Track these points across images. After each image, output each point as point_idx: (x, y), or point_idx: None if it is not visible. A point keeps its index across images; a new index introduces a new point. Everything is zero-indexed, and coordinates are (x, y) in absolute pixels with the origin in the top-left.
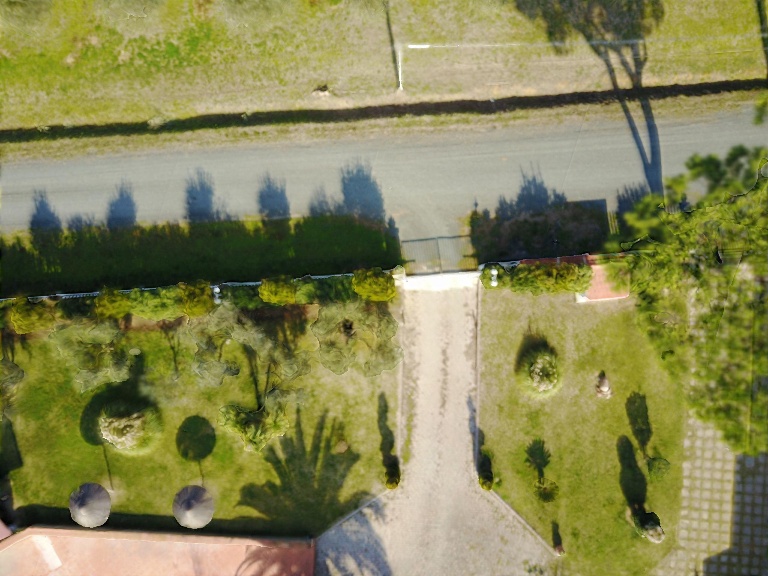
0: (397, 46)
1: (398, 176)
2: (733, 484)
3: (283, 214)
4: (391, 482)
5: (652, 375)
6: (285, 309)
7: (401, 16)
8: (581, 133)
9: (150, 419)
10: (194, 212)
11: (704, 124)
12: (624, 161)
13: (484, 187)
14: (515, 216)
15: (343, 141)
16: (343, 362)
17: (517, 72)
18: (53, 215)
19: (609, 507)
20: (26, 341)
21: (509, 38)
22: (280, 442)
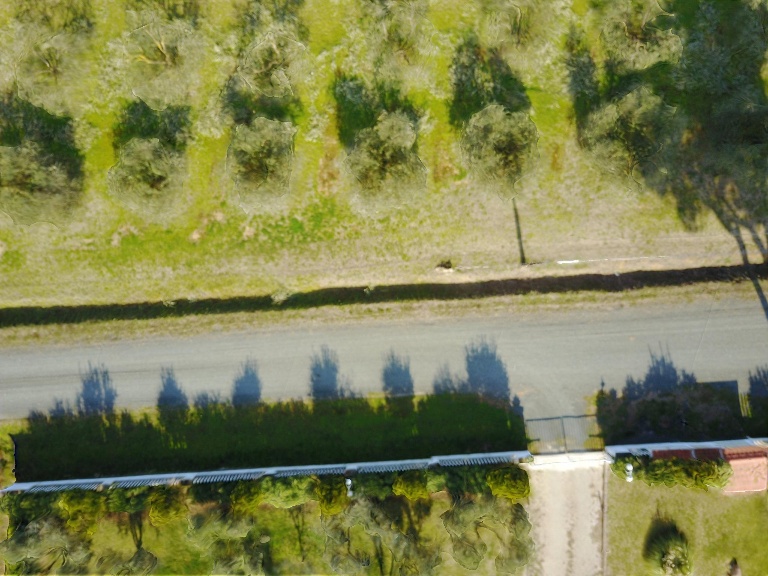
0: (522, 221)
1: (523, 355)
2: None
3: (406, 392)
4: None
5: None
6: None
7: (526, 191)
8: (712, 313)
9: None
10: (318, 389)
11: None
12: (756, 342)
13: (611, 366)
14: (642, 396)
15: (467, 319)
16: (478, 562)
17: (644, 248)
18: (180, 392)
19: None
20: None
21: (636, 214)
22: None
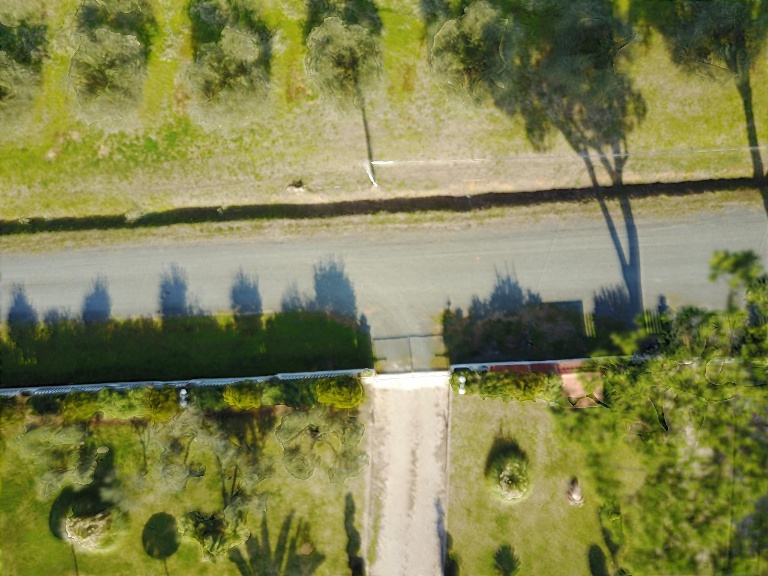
0: (372, 142)
1: (371, 273)
2: None
3: (255, 309)
4: None
5: (627, 484)
6: None
7: (377, 112)
8: (558, 233)
9: (116, 517)
10: (167, 306)
11: (686, 226)
12: (602, 262)
13: (457, 286)
14: (489, 316)
15: (316, 237)
16: (305, 470)
17: (494, 169)
18: (30, 307)
19: None
20: (1, 431)
21: (486, 135)
22: (245, 542)
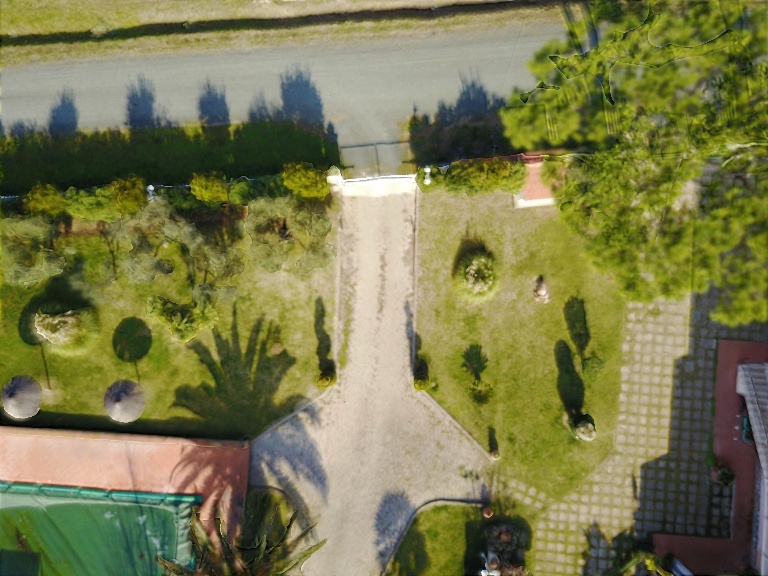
0: None
1: (337, 82)
2: (672, 389)
3: (222, 120)
4: (321, 378)
5: (590, 280)
6: (224, 214)
7: None
8: (520, 38)
9: (86, 318)
10: (135, 118)
11: None
12: None
13: (423, 93)
14: (454, 122)
15: (282, 48)
16: (273, 256)
17: None
18: None
19: (546, 412)
20: None
21: None
22: (216, 344)
